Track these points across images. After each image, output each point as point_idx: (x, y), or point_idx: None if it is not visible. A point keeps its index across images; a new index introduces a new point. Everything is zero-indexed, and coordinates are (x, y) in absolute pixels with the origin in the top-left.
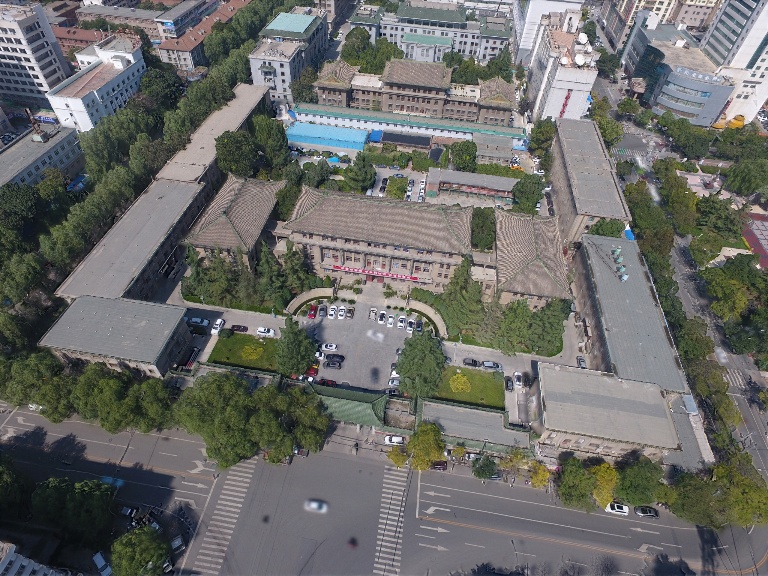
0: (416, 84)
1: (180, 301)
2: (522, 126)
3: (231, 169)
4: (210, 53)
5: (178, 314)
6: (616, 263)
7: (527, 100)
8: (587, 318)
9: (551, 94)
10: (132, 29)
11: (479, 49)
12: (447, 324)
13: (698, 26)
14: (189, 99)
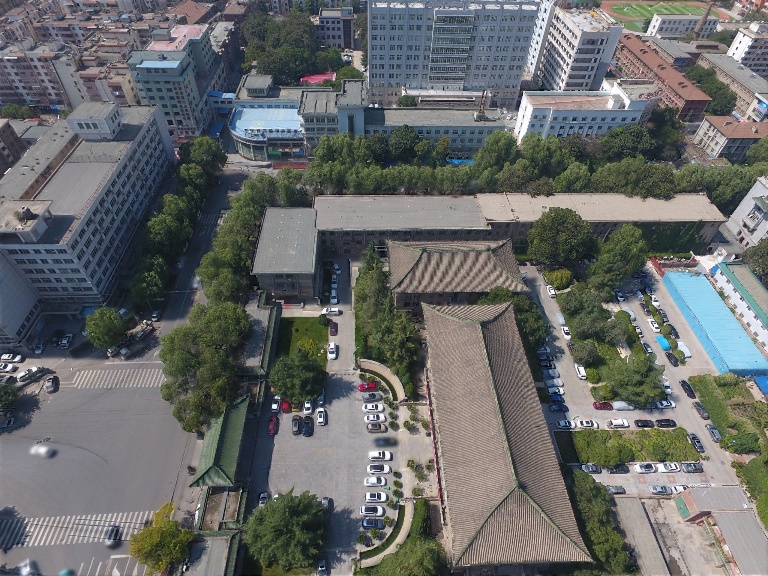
0: None
1: (357, 276)
2: None
3: (533, 241)
4: (753, 153)
5: (306, 269)
6: None
7: None
8: None
9: None
10: (726, 92)
11: None
12: None
13: None
14: None
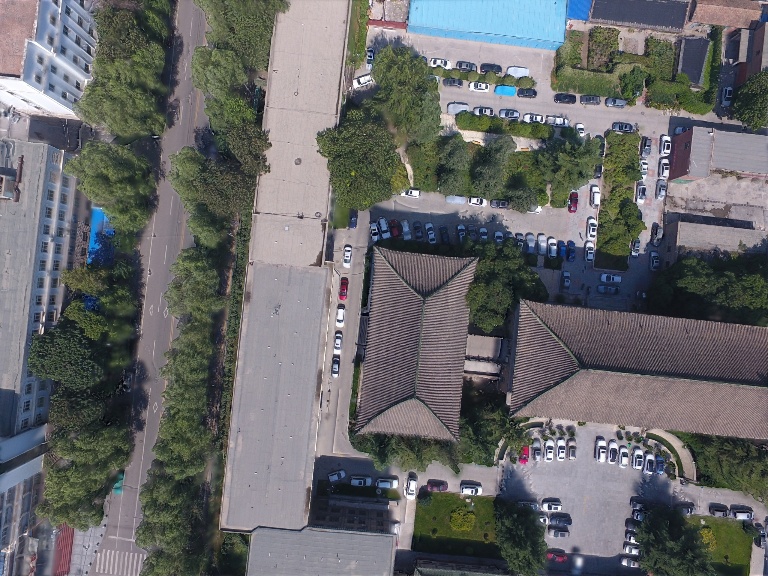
0: None
1: (350, 447)
2: None
3: (360, 203)
4: None
5: (389, 545)
6: None
7: None
8: None
9: None
10: None
11: None
12: None
13: None
14: None
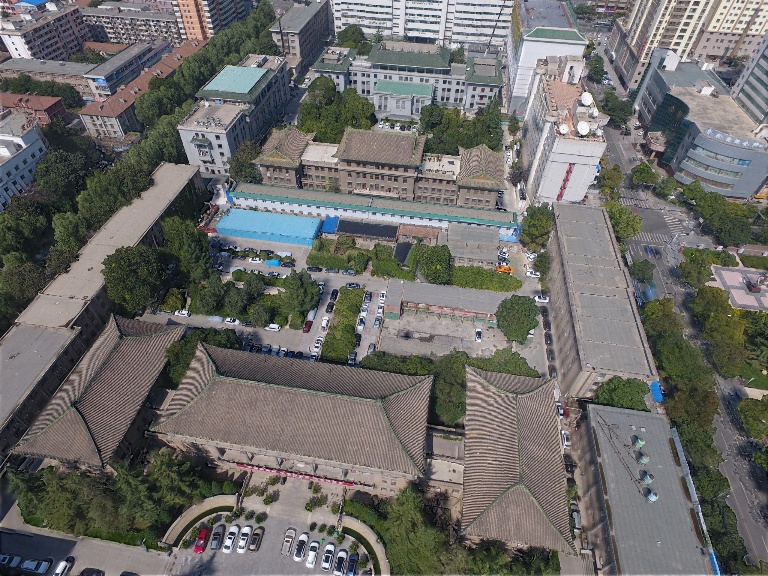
0: (378, 161)
1: (20, 521)
2: (514, 201)
3: (125, 298)
4: (143, 117)
5: None
6: (639, 463)
7: (520, 168)
8: (598, 552)
9: (548, 168)
10: (59, 87)
11: (465, 96)
12: (392, 565)
13: (722, 55)
14: (89, 193)
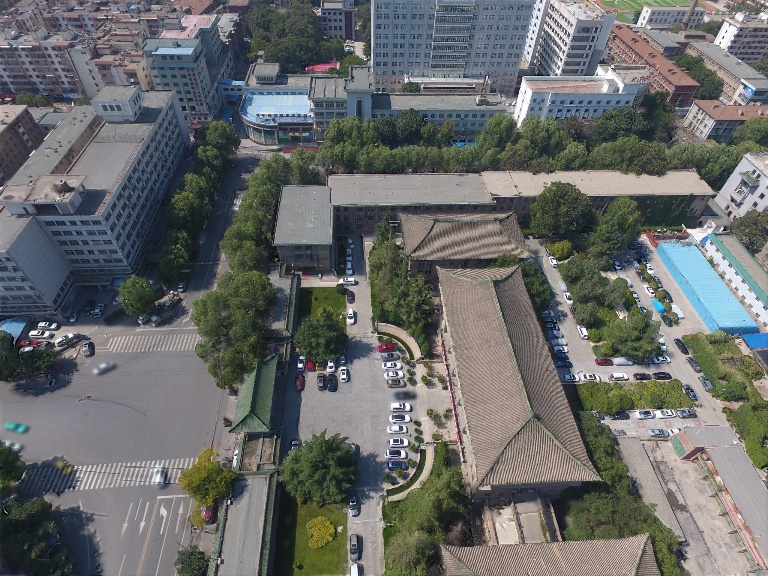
0: None
1: None
2: None
3: (536, 215)
4: (739, 135)
5: (324, 241)
6: None
7: None
8: None
9: None
10: (713, 78)
11: None
12: None
13: None
14: None
